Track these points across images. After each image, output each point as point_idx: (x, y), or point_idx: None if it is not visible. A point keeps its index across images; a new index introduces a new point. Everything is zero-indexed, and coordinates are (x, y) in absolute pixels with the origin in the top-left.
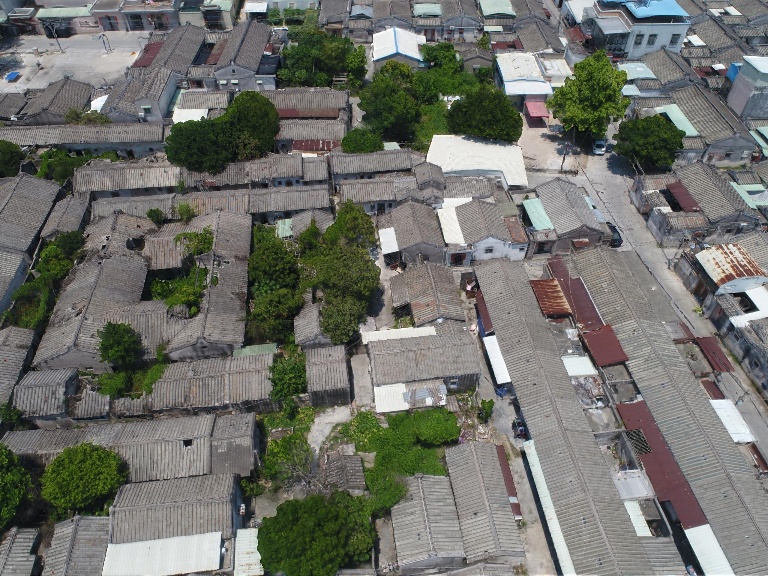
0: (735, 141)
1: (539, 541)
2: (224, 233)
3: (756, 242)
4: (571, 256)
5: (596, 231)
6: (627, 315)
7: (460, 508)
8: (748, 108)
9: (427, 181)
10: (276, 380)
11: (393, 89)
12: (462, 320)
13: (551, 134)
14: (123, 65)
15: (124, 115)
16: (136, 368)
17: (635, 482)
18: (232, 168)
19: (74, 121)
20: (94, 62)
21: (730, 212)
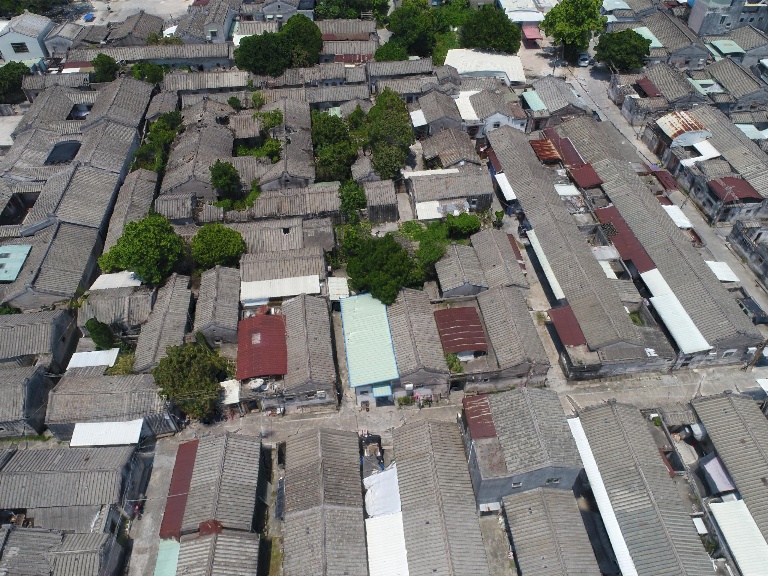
0: (692, 50)
1: (539, 292)
2: (290, 113)
3: (703, 112)
4: (560, 124)
5: (580, 109)
6: (602, 156)
7: (483, 265)
8: (704, 27)
9: (446, 77)
10: (344, 196)
11: (415, 12)
12: (478, 164)
13: (544, 53)
14: (180, 8)
15: (194, 38)
16: (235, 199)
17: (607, 251)
18: (289, 72)
19: (154, 43)
20: (155, 7)
21: (684, 94)
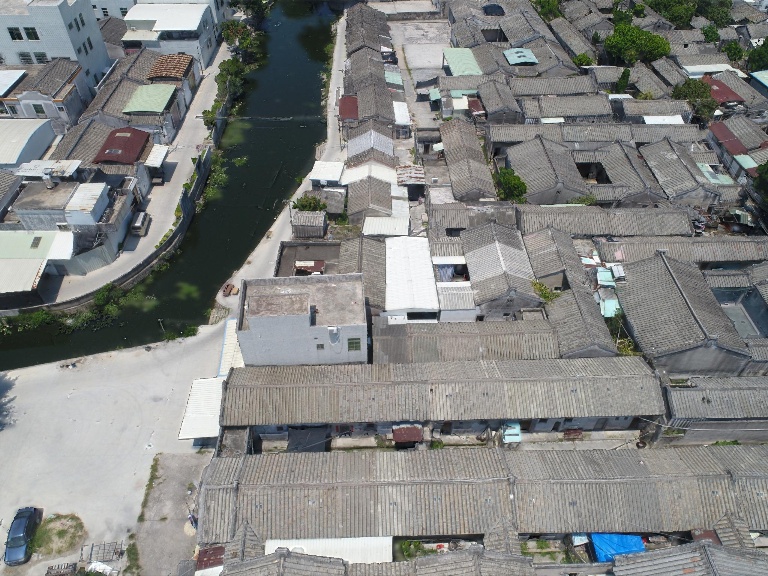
0: None
1: None
2: None
3: None
4: None
5: None
6: None
7: None
8: None
9: None
10: (707, 32)
11: None
12: None
13: None
14: None
15: None
16: None
17: None
18: None
19: None
20: None
21: None
